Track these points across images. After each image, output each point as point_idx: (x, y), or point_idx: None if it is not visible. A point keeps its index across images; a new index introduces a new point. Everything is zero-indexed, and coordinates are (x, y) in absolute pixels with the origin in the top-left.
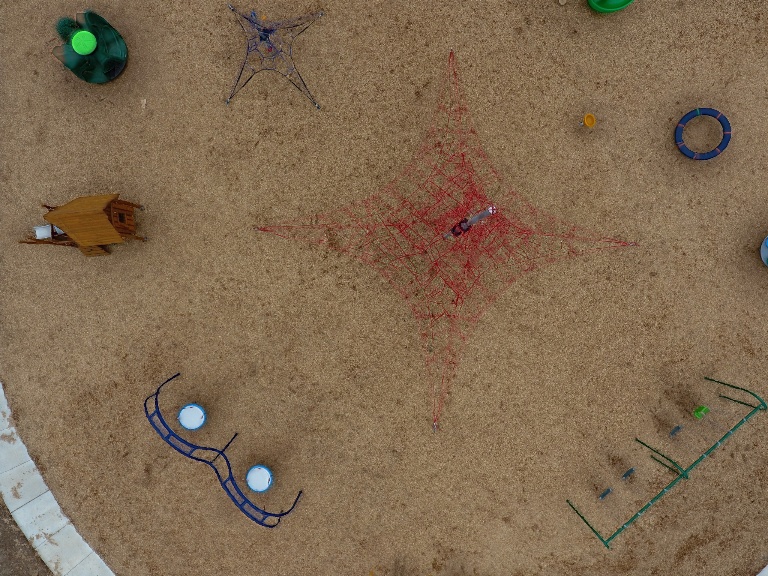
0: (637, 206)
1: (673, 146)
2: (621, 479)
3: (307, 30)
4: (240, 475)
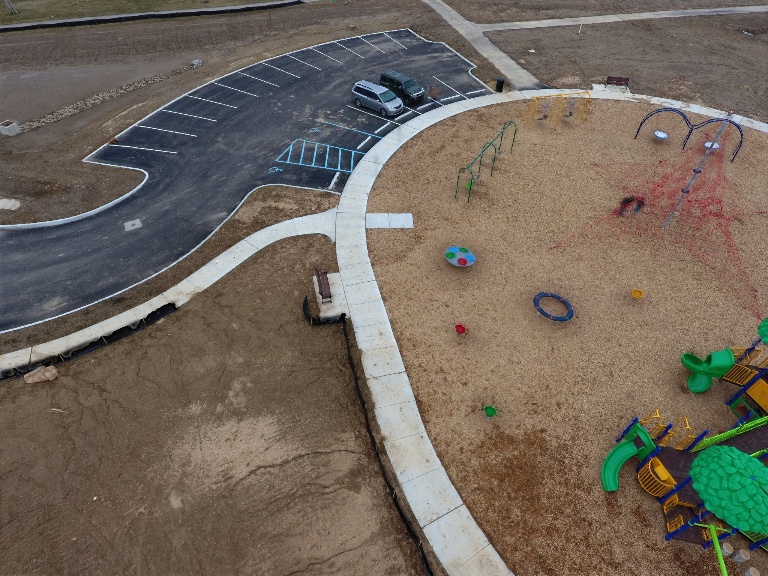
0: None
1: None
2: (488, 164)
3: None
4: (667, 139)
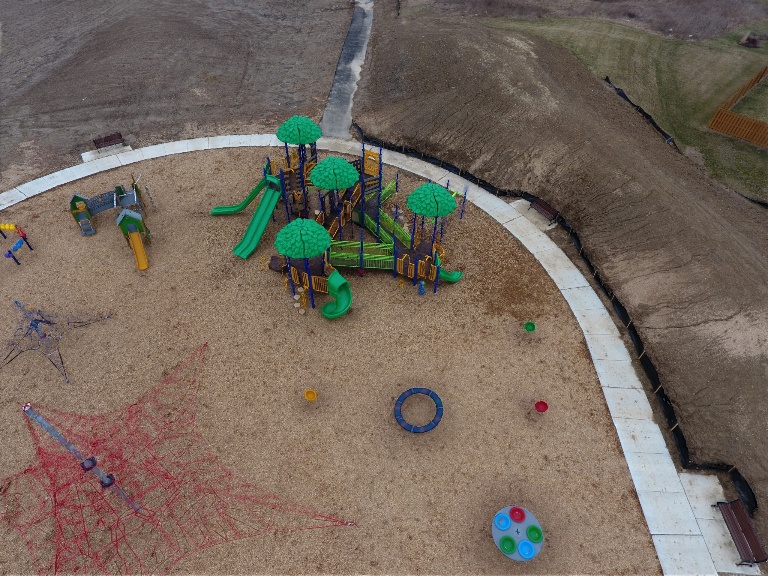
0: (357, 480)
1: (395, 421)
2: None
3: (91, 327)
4: None
